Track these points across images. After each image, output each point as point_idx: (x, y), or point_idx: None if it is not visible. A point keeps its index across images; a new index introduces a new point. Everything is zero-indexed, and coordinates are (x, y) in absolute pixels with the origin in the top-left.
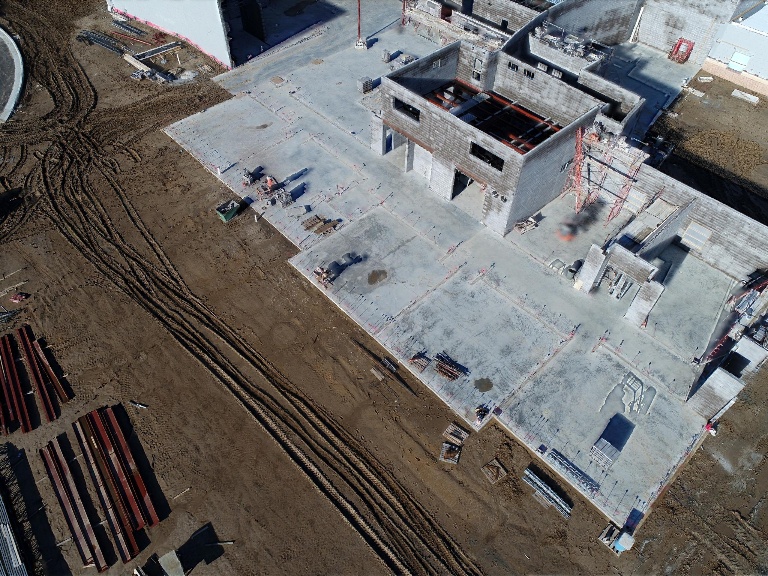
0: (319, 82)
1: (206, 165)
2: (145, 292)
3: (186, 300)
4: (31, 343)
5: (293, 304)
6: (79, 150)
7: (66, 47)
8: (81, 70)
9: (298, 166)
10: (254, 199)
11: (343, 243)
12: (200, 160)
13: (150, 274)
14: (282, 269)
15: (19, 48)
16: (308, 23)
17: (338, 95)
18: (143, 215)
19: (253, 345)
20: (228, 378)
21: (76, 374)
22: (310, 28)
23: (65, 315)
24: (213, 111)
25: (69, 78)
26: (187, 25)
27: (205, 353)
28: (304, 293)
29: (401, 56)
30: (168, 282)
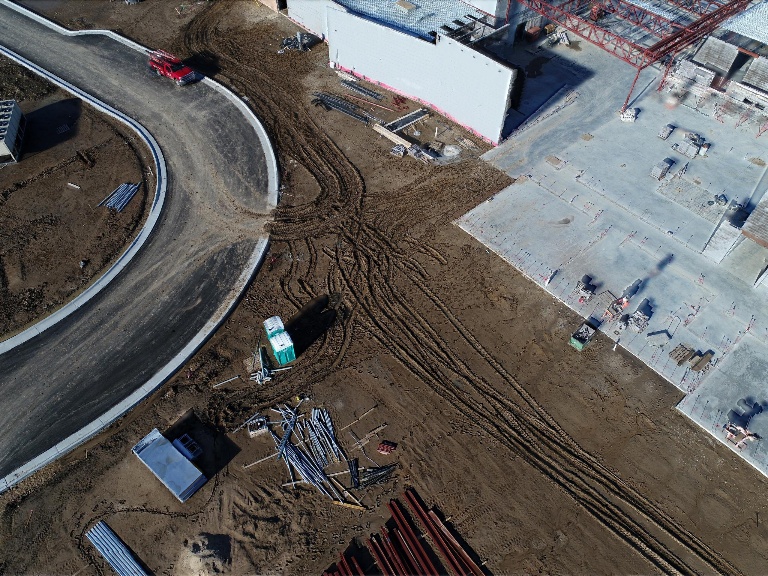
0: (601, 164)
1: (525, 272)
2: (526, 444)
3: (579, 458)
4: (427, 514)
5: (708, 469)
6: (371, 247)
7: (303, 112)
8: (332, 142)
9: (629, 276)
10: (600, 320)
11: (730, 384)
12: (516, 265)
13: (521, 419)
14: (673, 418)
15: (253, 112)
16: (554, 87)
17: (630, 181)
18: (479, 337)
19: (686, 526)
20: (677, 574)
21: (495, 561)
22: (559, 93)
23: (448, 474)
24: (501, 200)
25: (322, 152)
26: (440, 92)
27: (635, 536)
28: (715, 454)
29: (677, 132)
30: (547, 431)
